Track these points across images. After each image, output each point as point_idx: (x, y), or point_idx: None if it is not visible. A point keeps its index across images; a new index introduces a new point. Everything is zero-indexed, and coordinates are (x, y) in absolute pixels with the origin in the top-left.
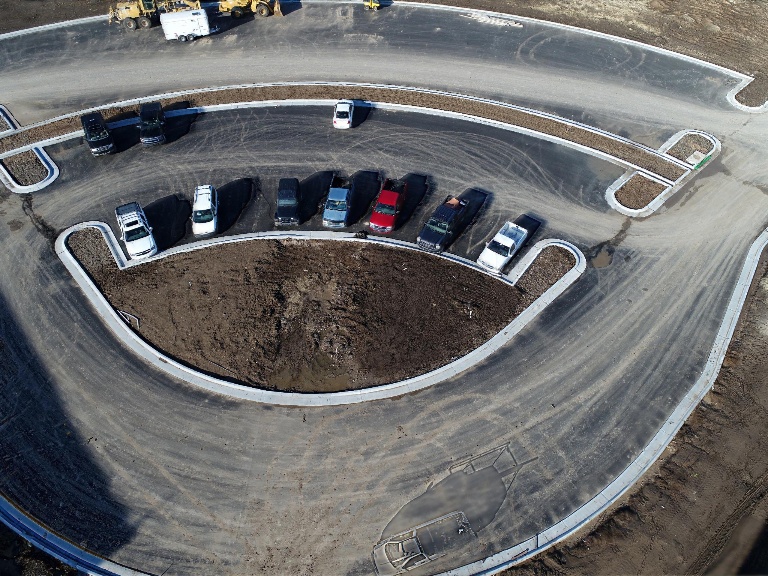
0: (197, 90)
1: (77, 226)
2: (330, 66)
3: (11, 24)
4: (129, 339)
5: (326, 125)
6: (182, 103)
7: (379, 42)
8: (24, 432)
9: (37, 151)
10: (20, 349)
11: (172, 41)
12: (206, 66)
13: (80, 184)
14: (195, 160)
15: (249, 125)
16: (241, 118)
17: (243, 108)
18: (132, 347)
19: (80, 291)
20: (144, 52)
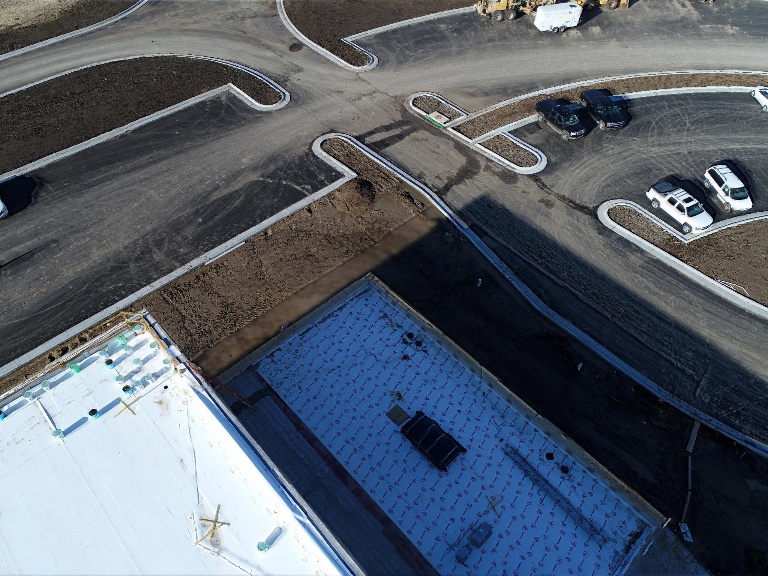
0: (606, 78)
1: (607, 204)
2: (711, 55)
3: (382, 17)
4: (749, 305)
5: (756, 110)
6: (602, 90)
7: (738, 32)
8: (727, 387)
9: (507, 135)
10: (656, 314)
11: (543, 33)
12: (595, 56)
13: (574, 166)
14: (662, 143)
15: (683, 111)
16: (670, 104)
17: (663, 95)
18: (758, 312)
19: (663, 262)
20: (526, 43)
